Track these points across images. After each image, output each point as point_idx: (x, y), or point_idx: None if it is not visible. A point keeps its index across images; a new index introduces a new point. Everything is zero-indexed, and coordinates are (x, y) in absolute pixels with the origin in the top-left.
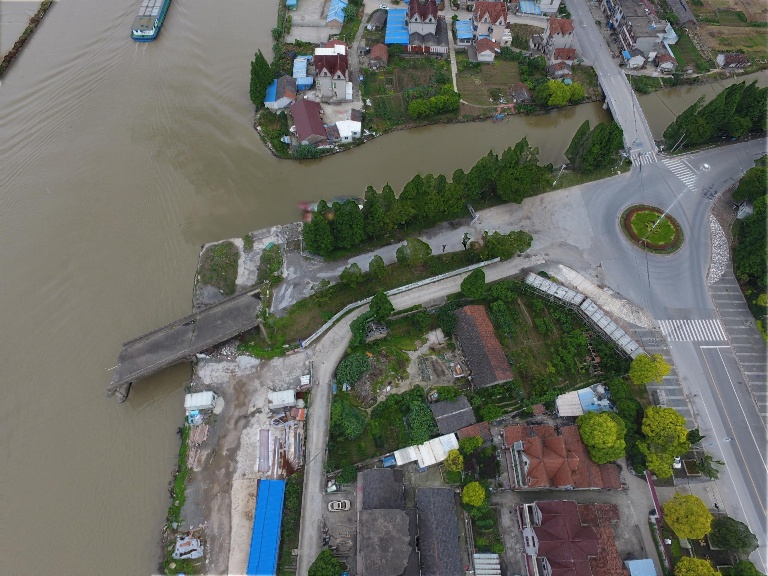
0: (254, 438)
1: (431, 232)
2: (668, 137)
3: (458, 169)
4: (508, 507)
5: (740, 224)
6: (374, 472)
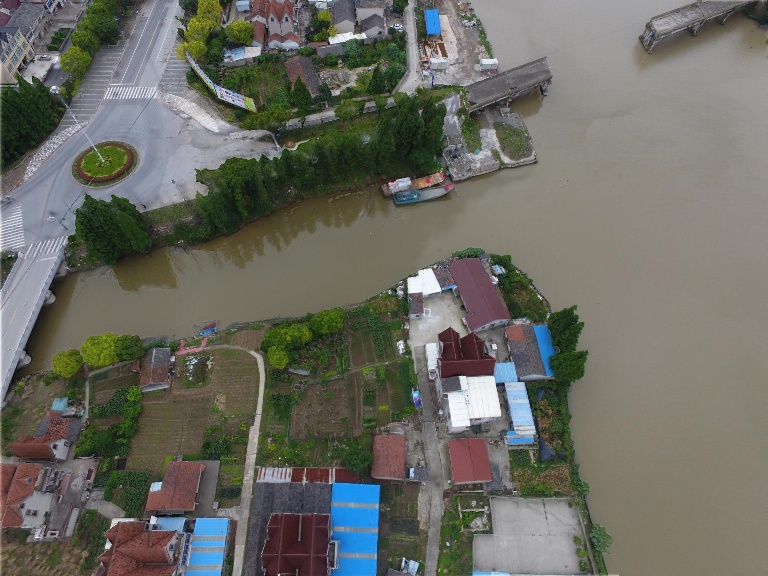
0: (450, 55)
1: None
2: None
3: (299, 156)
4: (304, 26)
5: (4, 169)
6: (378, 26)
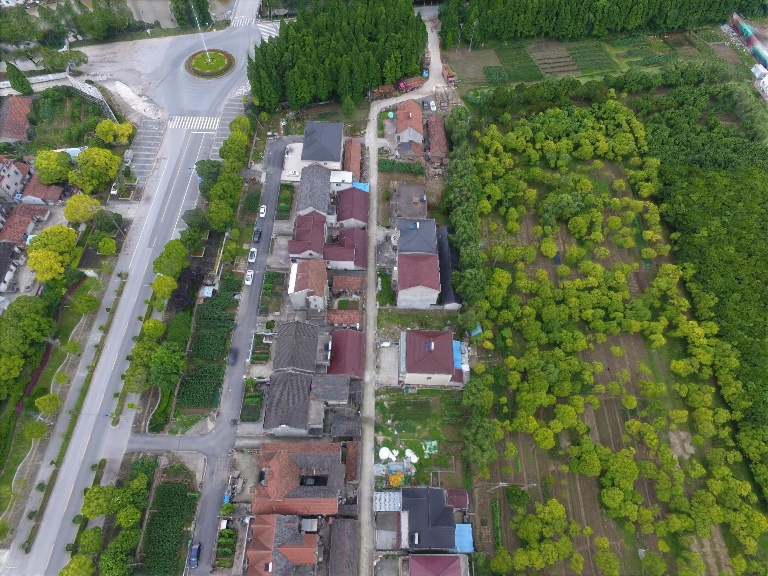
0: None
1: (26, 58)
2: (265, 6)
3: None
4: None
5: None
6: None
